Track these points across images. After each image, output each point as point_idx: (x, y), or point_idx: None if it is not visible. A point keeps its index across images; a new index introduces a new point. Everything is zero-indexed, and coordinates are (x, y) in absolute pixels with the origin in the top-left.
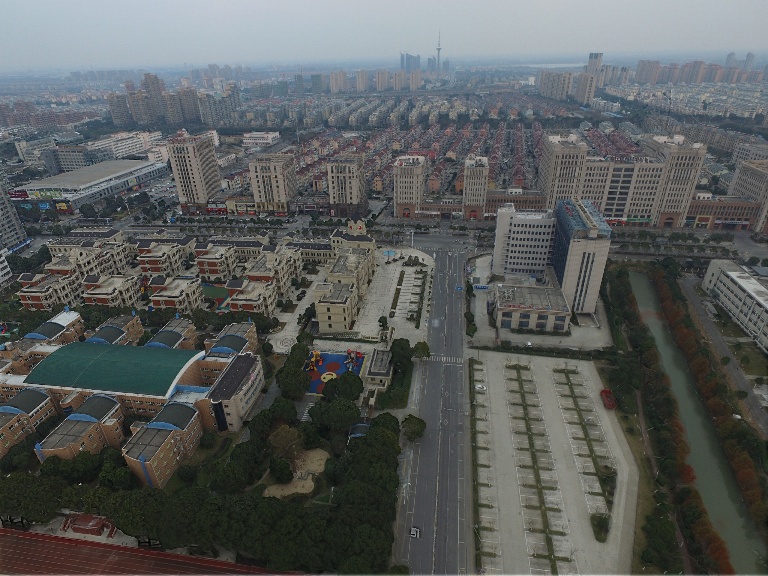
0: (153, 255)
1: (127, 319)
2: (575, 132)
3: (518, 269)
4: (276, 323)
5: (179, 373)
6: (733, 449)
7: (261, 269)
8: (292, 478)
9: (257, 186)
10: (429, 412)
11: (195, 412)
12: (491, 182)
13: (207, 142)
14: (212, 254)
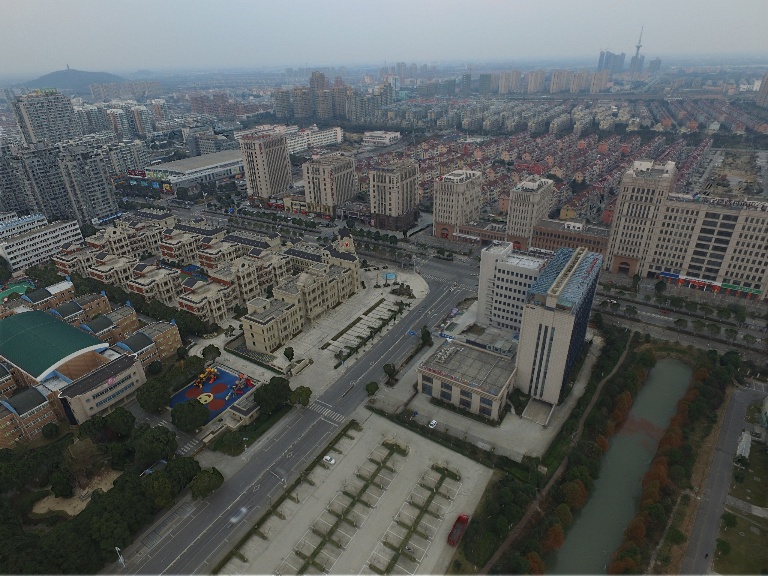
0: (169, 242)
1: (96, 298)
2: (762, 155)
3: (505, 324)
4: (214, 329)
5: (61, 360)
6: None
7: (226, 272)
8: (68, 495)
9: (308, 187)
10: (252, 470)
11: (45, 401)
12: (570, 210)
13: (279, 140)
14: (214, 249)
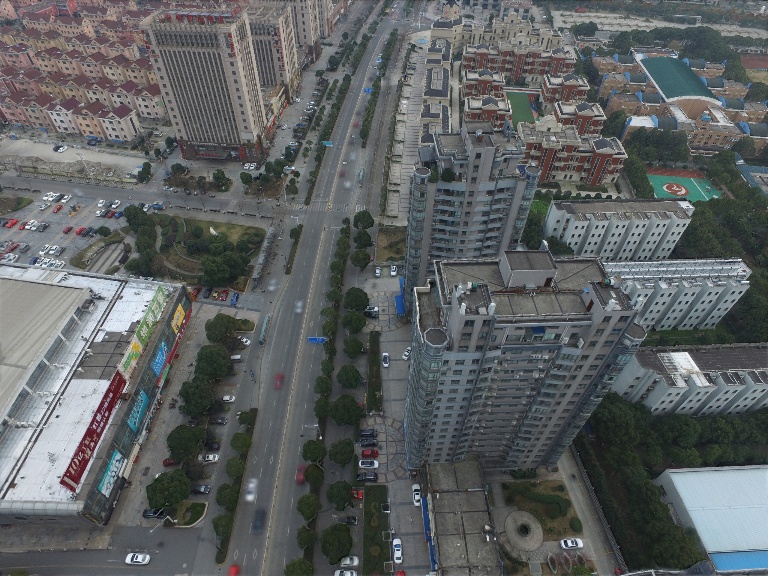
0: None
1: (620, 96)
2: None
3: None
4: None
5: None
6: (599, 0)
7: (532, 47)
8: None
9: None
10: None
11: None
12: None
13: None
14: None
